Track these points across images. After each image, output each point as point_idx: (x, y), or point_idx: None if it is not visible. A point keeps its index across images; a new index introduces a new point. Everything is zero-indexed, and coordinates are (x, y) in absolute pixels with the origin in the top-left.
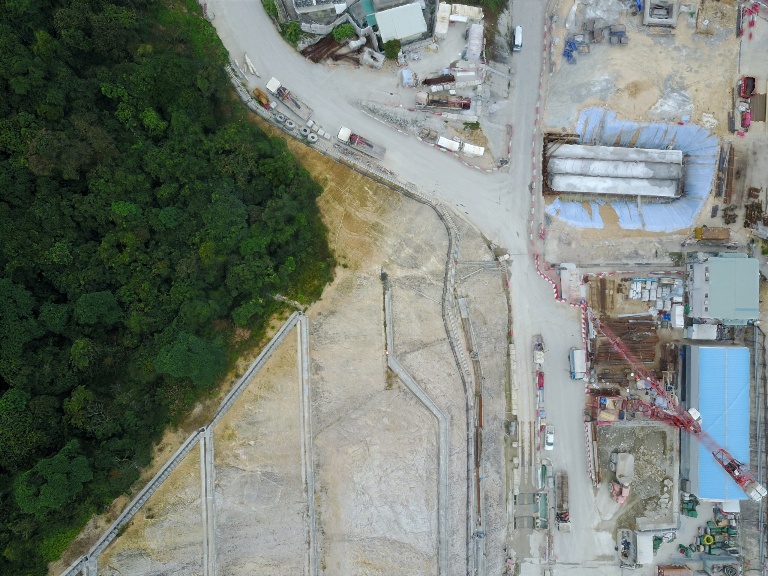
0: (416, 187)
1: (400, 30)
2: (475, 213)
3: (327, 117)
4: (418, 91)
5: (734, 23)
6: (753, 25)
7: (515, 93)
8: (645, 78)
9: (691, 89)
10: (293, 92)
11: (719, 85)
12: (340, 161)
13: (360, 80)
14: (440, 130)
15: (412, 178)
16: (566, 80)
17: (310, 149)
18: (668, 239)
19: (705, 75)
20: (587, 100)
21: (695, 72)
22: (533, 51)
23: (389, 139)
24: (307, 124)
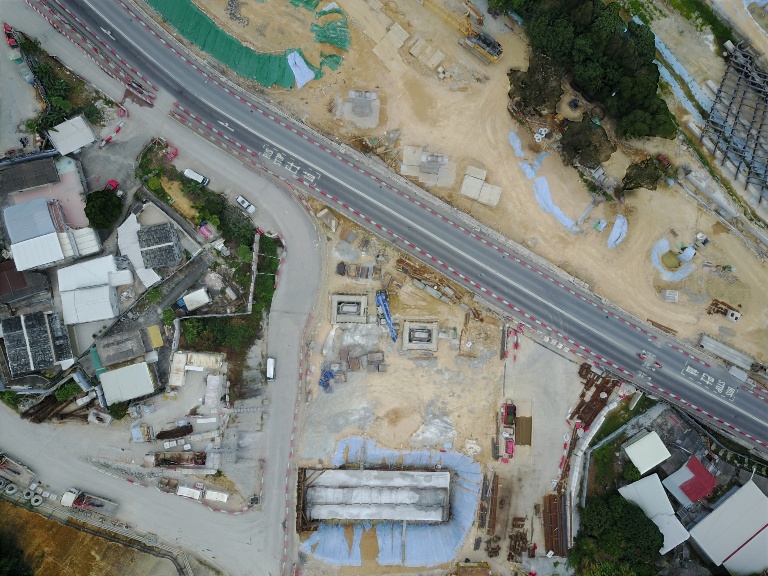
0: (156, 537)
1: (125, 392)
2: (223, 557)
3: (55, 475)
4: (152, 445)
5: (498, 344)
6: (517, 347)
7: (269, 424)
8: (406, 404)
9: (453, 415)
10: (15, 454)
11: (482, 410)
12: (67, 523)
13: (89, 436)
14: (181, 478)
15: (152, 528)
16: (323, 409)
17: (32, 514)
18: (428, 575)
19: (468, 400)
20: (345, 429)
21: (458, 397)
22: (289, 379)
23: (125, 491)
24: (30, 488)
